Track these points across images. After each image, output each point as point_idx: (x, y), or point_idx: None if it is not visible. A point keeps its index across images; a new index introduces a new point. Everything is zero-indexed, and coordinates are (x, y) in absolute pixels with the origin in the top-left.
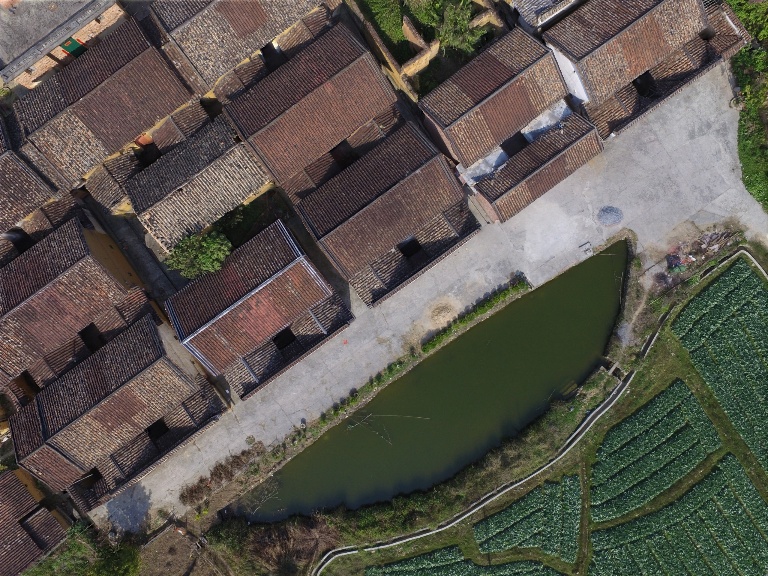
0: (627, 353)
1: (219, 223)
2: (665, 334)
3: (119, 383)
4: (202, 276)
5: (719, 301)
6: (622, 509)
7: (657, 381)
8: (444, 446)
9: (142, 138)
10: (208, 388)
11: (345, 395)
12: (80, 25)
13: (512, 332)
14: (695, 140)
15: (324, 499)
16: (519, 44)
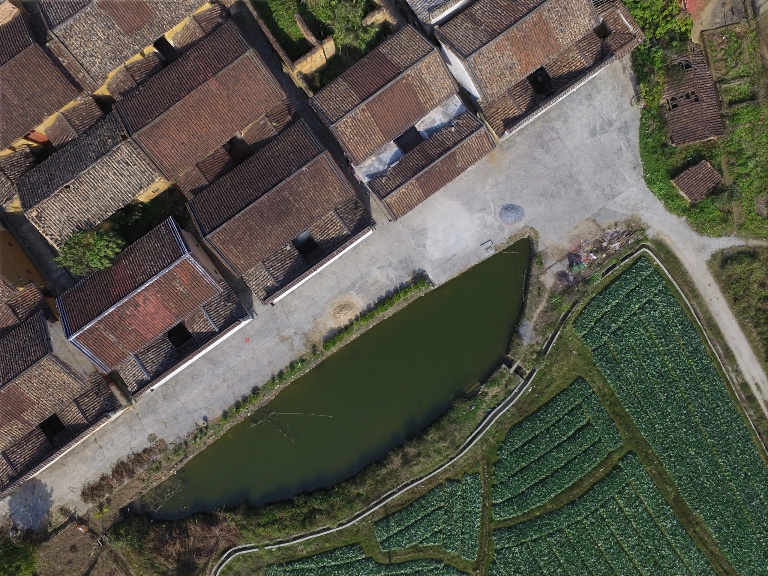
0: (528, 351)
1: (112, 220)
2: (567, 332)
3: (6, 380)
4: (93, 273)
5: (620, 299)
6: (523, 507)
7: (559, 379)
8: (347, 444)
9: (33, 135)
10: (103, 385)
11: (247, 393)
12: None
13: (415, 330)
14: (596, 138)
15: (228, 497)
16: (408, 41)
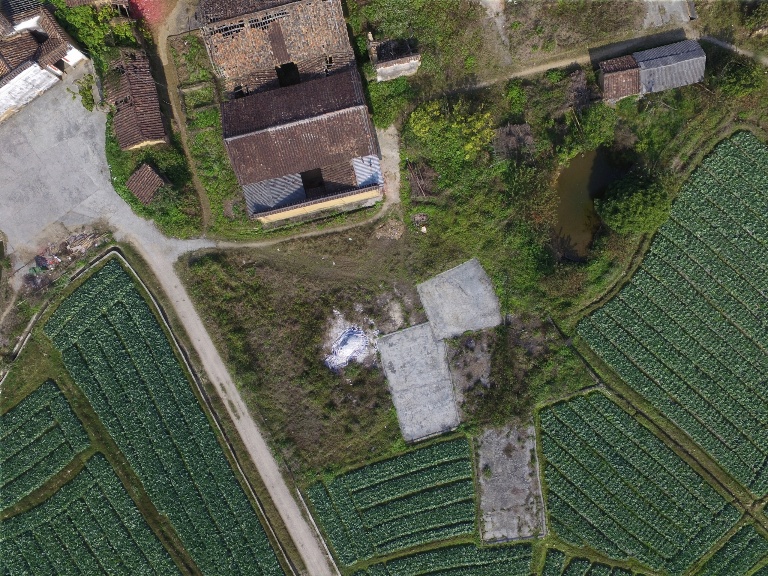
0: None
1: None
2: (38, 335)
3: None
4: None
5: (88, 302)
6: None
7: (29, 382)
8: None
9: None
10: None
11: None
12: None
13: None
14: (63, 142)
15: None
16: None
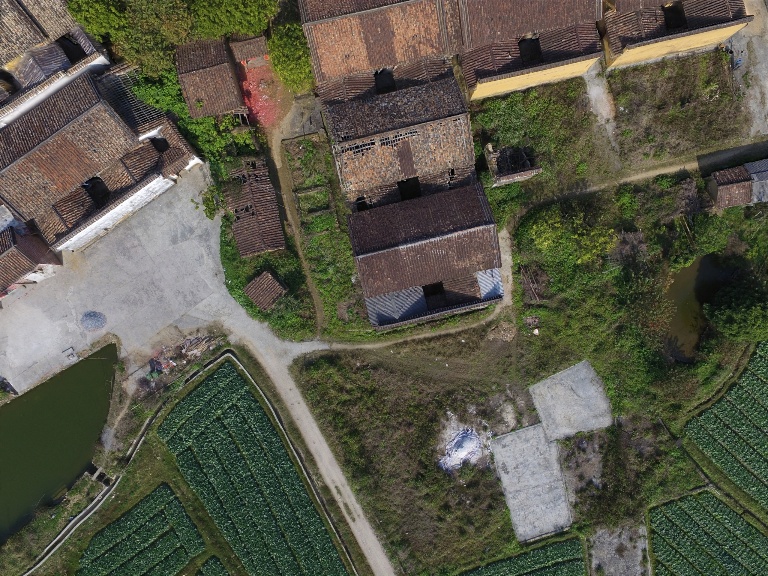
0: (110, 458)
1: None
2: (151, 438)
3: None
4: None
5: (202, 405)
6: None
7: (143, 485)
8: None
9: None
10: None
11: None
12: None
13: (1, 437)
14: (178, 245)
15: None
16: None
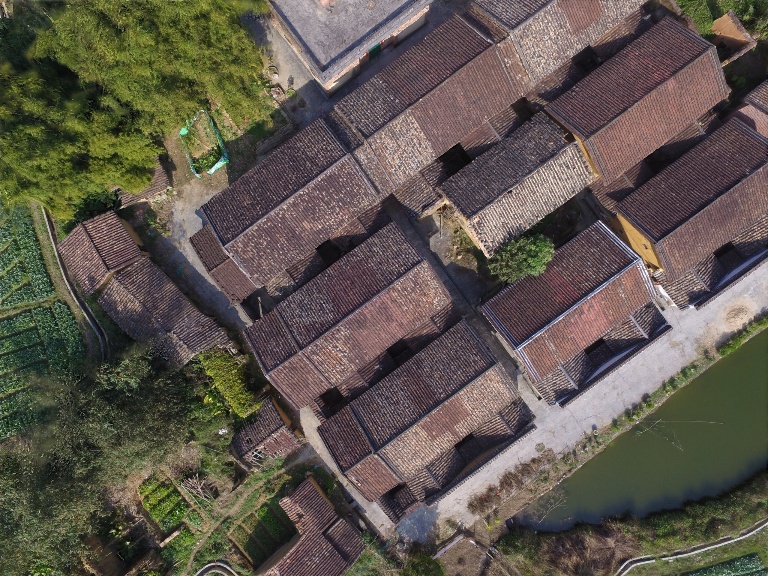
0: None
1: None
2: None
3: (449, 391)
4: (520, 280)
5: None
6: None
7: None
8: (735, 452)
9: None
10: None
11: (637, 400)
12: (399, 23)
13: None
14: None
15: (611, 507)
16: None
